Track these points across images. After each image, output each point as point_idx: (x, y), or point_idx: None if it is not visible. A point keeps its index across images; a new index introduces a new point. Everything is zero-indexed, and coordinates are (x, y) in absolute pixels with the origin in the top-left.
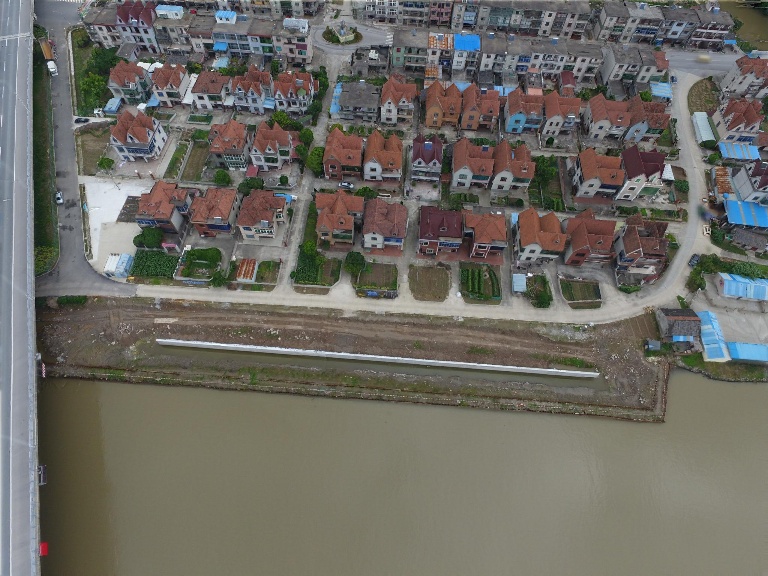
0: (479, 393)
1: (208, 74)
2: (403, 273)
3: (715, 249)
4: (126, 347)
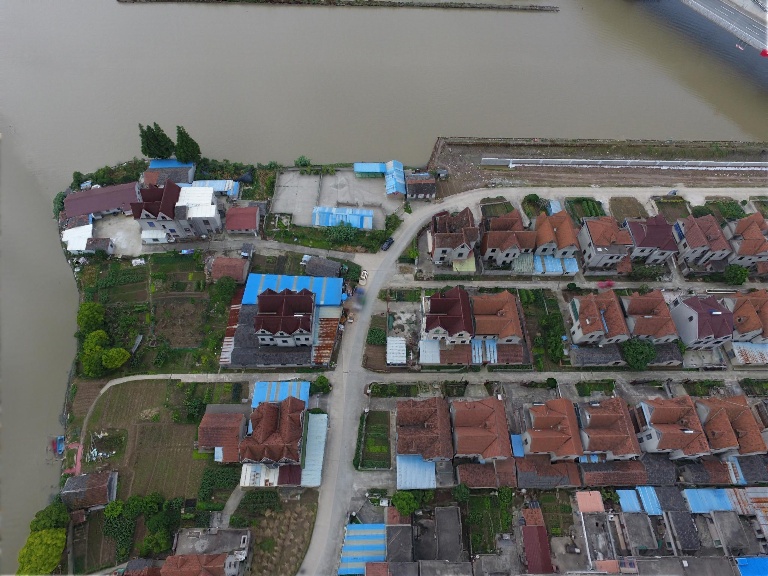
0: (563, 149)
1: None
2: None
3: (360, 260)
4: None
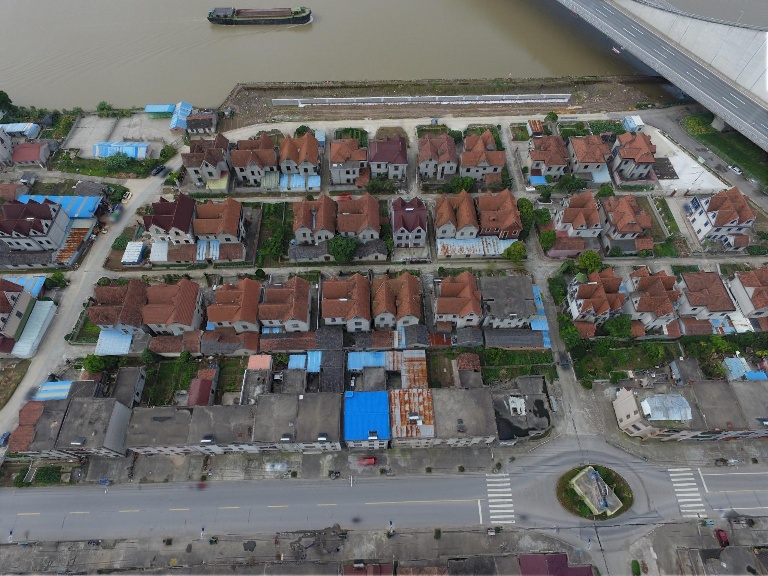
0: (353, 90)
1: (720, 299)
2: (414, 142)
3: (130, 184)
4: (589, 96)
